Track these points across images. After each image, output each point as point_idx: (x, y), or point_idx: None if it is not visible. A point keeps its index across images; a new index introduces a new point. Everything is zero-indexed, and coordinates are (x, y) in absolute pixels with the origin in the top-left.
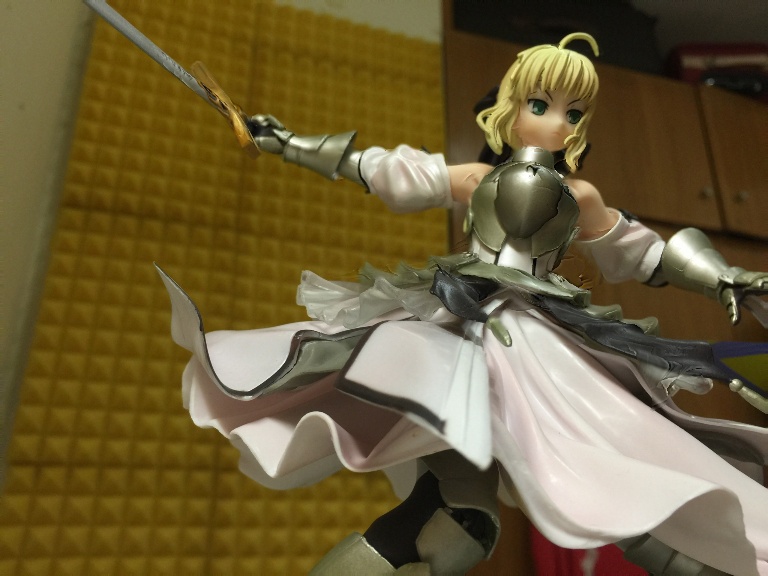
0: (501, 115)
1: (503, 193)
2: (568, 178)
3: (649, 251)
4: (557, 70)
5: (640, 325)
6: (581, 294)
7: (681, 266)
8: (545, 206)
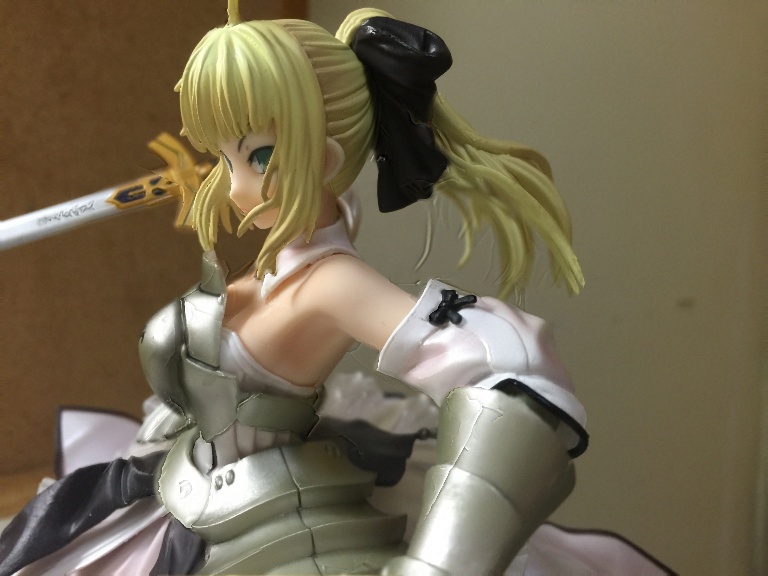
0: (214, 183)
1: None
2: (478, 168)
3: None
4: None
5: None
6: (199, 528)
7: None
8: None
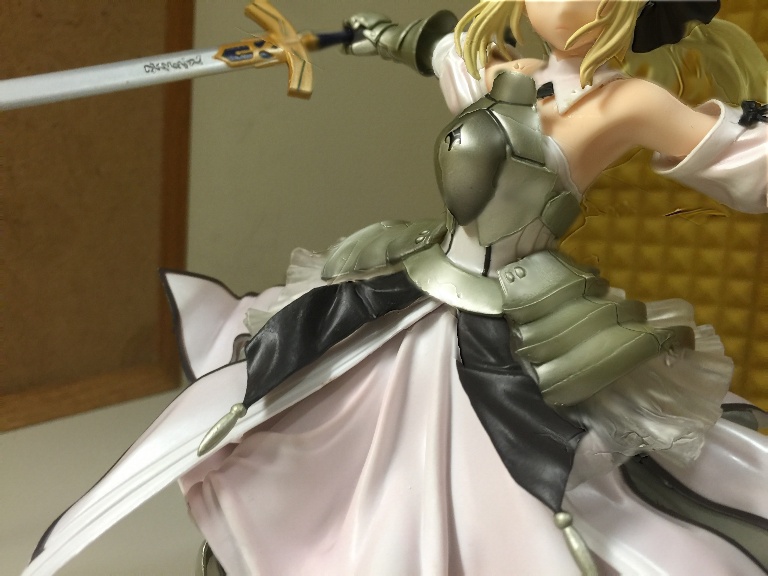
0: (490, 13)
1: (437, 166)
2: (720, 20)
3: None
4: None
5: (570, 368)
6: (512, 310)
7: None
8: (470, 189)
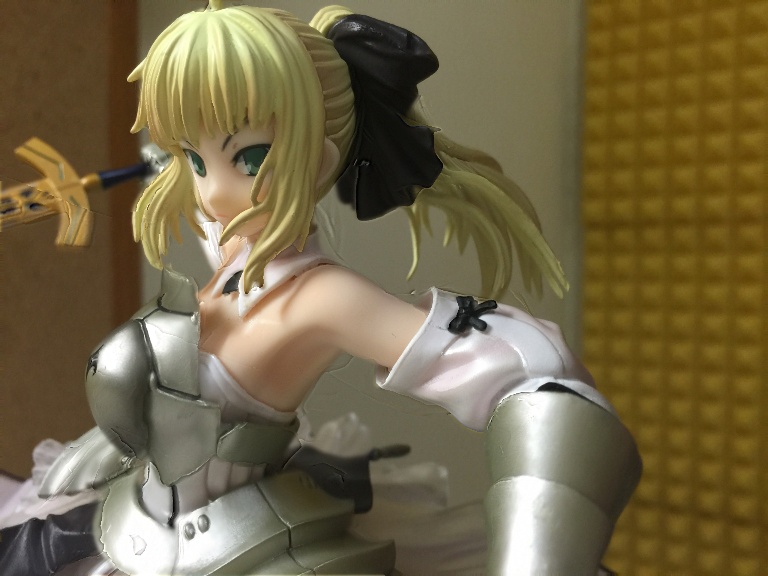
0: (166, 189)
1: None
2: (463, 174)
3: None
4: None
5: None
6: None
7: None
8: (118, 428)
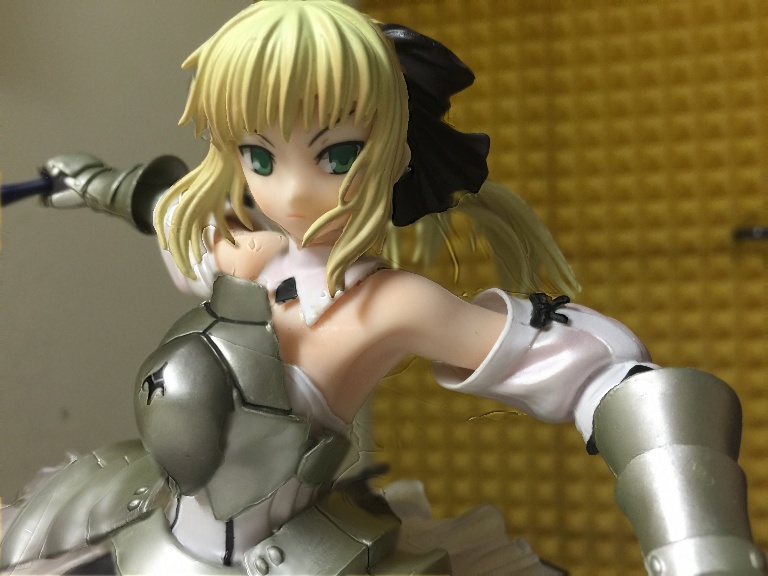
0: (200, 190)
1: None
2: (489, 182)
3: (584, 395)
4: (244, 89)
5: None
6: None
7: (615, 469)
8: (187, 457)
